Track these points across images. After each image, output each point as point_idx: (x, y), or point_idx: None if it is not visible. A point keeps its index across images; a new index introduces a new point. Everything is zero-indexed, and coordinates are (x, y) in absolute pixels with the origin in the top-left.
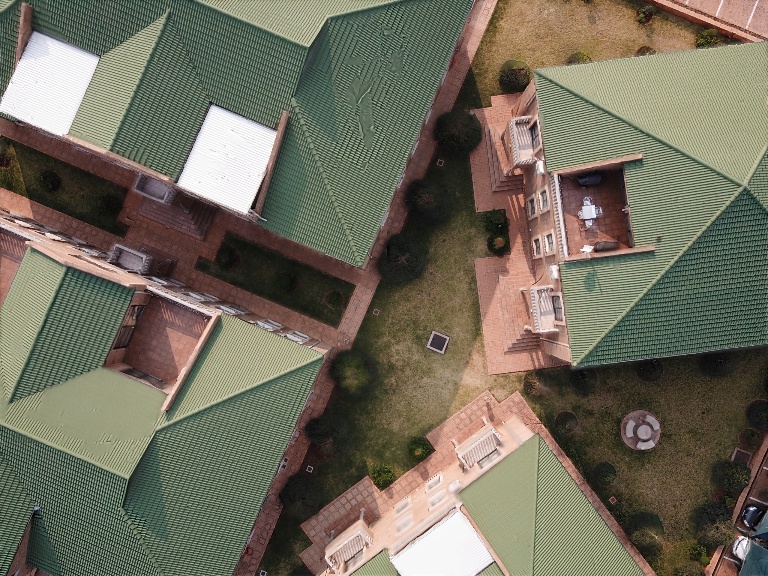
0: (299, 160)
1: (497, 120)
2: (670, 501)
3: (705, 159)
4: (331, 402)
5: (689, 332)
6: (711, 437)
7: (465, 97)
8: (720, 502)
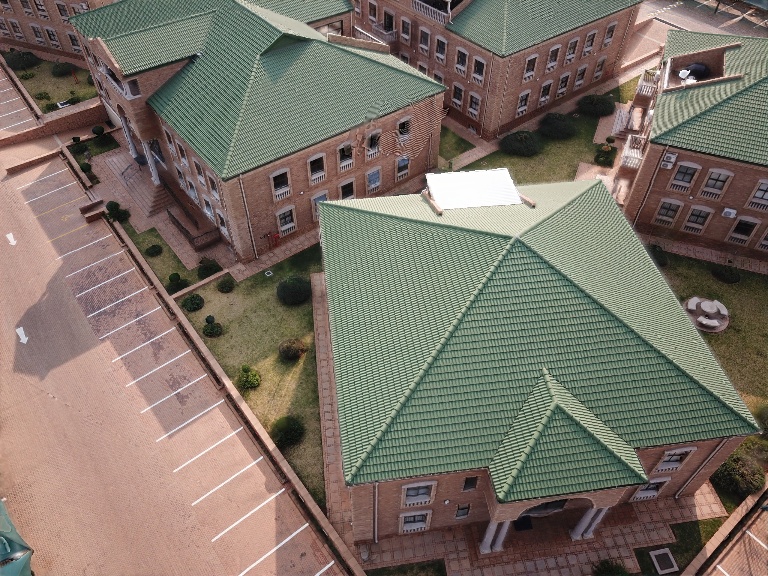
0: None
1: None
2: None
3: None
4: None
5: (767, 144)
6: None
7: None
8: None
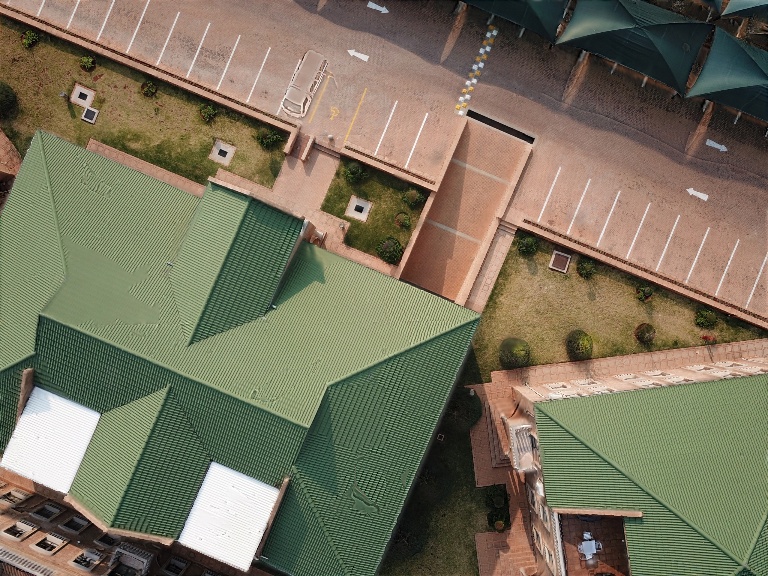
0: (300, 514)
1: (497, 396)
2: None
3: (705, 529)
4: None
5: None
6: None
7: (465, 373)
8: None
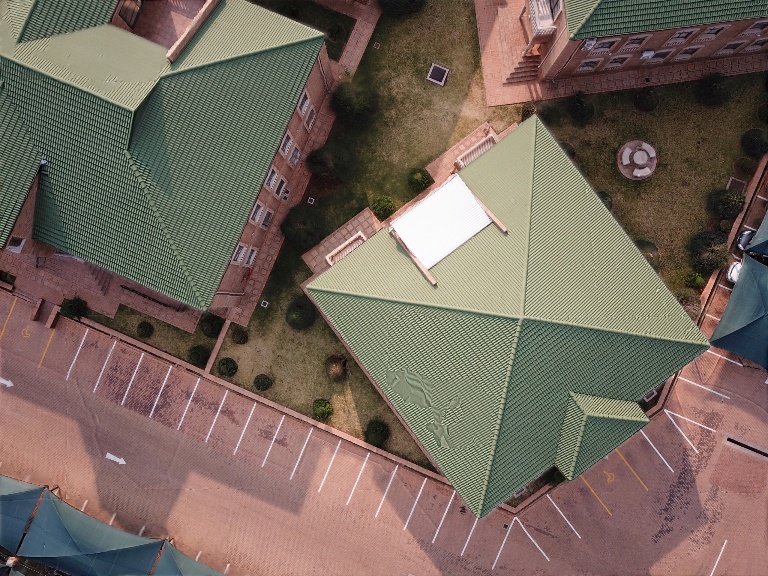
0: None
1: None
2: (666, 230)
3: None
4: (332, 134)
5: None
6: (706, 166)
7: None
8: (715, 230)
